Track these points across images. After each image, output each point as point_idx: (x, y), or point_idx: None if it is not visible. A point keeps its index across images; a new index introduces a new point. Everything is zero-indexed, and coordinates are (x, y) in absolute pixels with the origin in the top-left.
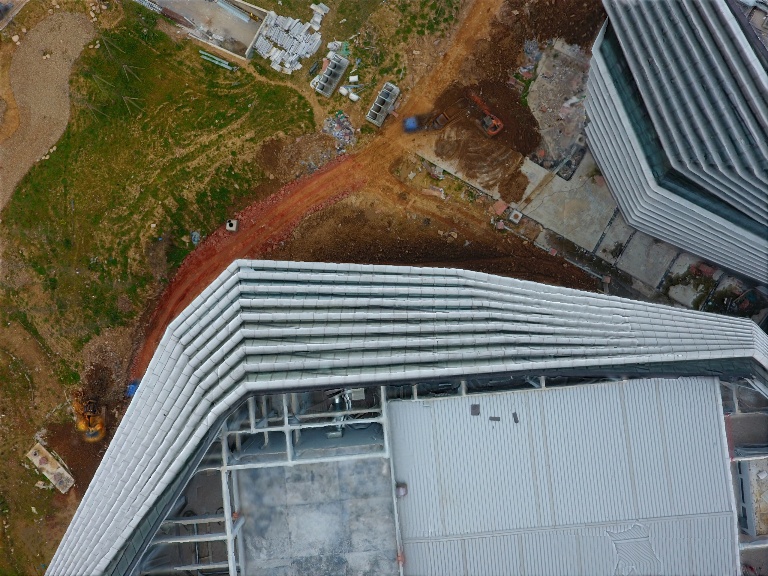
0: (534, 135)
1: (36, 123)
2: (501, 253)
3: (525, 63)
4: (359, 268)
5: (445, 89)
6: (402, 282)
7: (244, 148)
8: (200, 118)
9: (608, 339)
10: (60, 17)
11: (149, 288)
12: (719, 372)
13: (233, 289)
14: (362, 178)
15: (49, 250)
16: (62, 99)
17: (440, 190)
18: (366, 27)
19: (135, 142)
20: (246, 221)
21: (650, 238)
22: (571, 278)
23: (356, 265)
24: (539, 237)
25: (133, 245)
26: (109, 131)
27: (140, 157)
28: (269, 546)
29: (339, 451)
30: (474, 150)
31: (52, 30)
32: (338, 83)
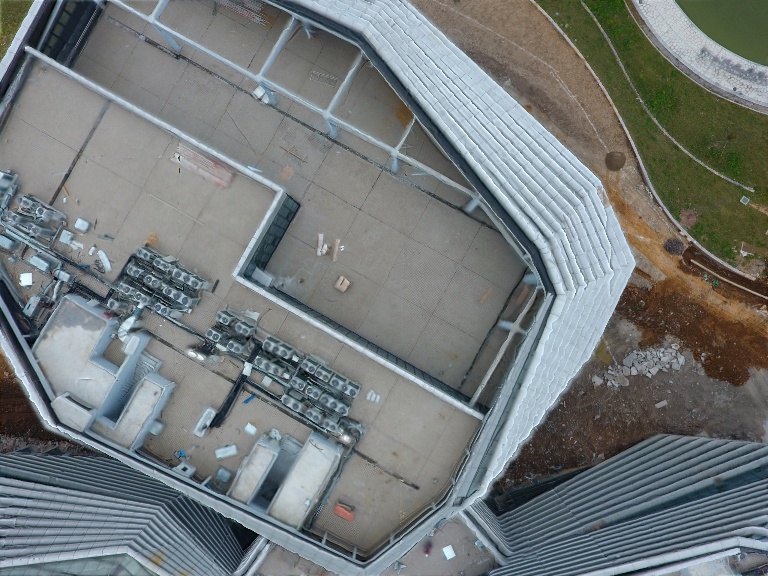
0: None
1: None
2: None
3: None
4: None
5: None
6: None
7: None
8: None
9: None
10: None
11: None
12: (73, 575)
13: None
14: None
15: None
16: None
17: None
18: None
19: None
20: None
21: None
22: None
23: None
24: None
25: None
26: None
27: None
28: None
29: None
30: None
31: None
32: None
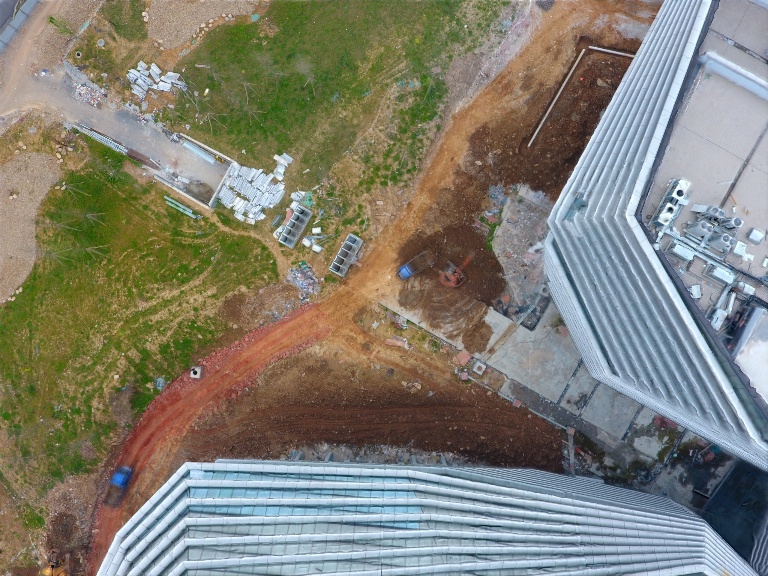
0: (499, 281)
1: (3, 263)
2: (465, 404)
3: (490, 207)
4: (309, 470)
5: (409, 238)
6: (352, 488)
7: (206, 304)
8: (163, 270)
9: (556, 560)
10: (27, 158)
11: (113, 435)
12: None
13: (180, 502)
14: (326, 327)
15: (14, 395)
16: (28, 239)
17: (404, 340)
18: (329, 178)
19: (99, 289)
20: (211, 367)
21: (614, 390)
22: (535, 430)
23: (306, 467)
24: (503, 387)
25: (96, 395)
26: (74, 275)
27: (104, 306)
28: None
29: None
30: (438, 300)
31: (19, 170)
32: (301, 234)
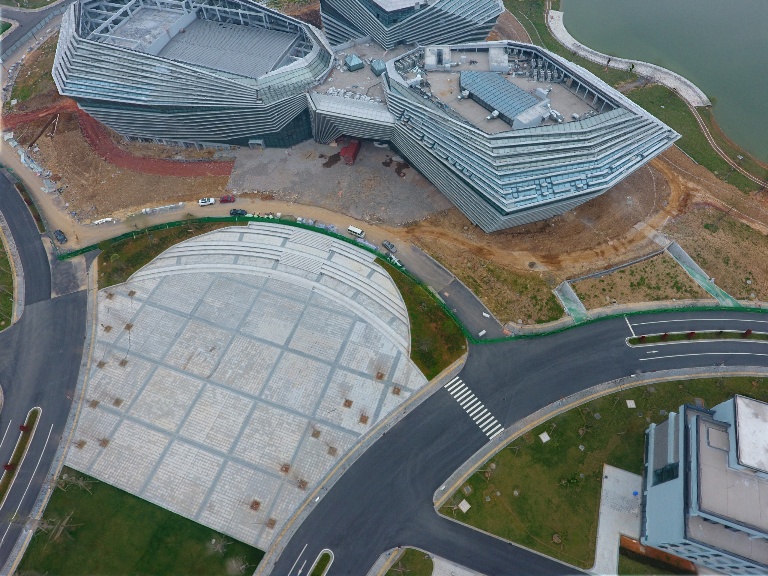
0: None
1: None
2: None
3: None
4: None
5: None
6: None
7: None
8: None
9: None
10: None
11: None
12: None
13: None
14: None
15: None
16: None
17: None
18: None
19: None
20: None
21: None
22: None
23: None
24: None
25: None
26: None
27: None
28: (133, 24)
29: (172, 13)
30: None
31: None
32: None
